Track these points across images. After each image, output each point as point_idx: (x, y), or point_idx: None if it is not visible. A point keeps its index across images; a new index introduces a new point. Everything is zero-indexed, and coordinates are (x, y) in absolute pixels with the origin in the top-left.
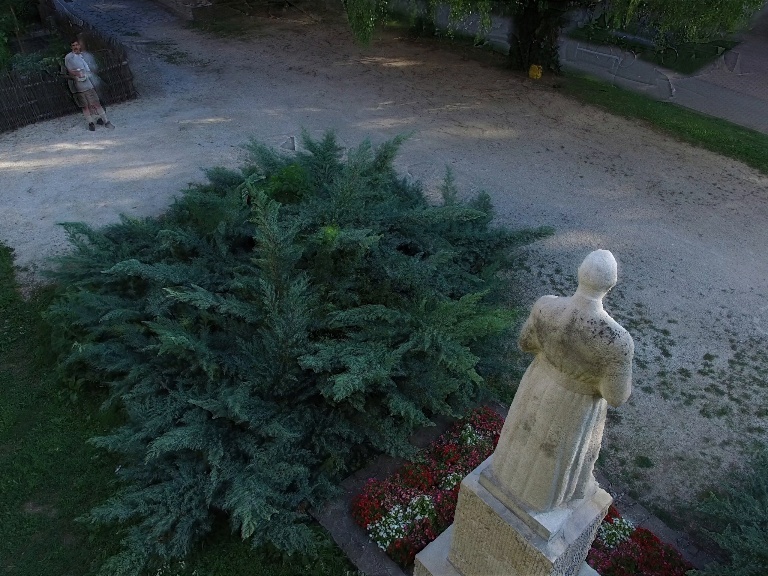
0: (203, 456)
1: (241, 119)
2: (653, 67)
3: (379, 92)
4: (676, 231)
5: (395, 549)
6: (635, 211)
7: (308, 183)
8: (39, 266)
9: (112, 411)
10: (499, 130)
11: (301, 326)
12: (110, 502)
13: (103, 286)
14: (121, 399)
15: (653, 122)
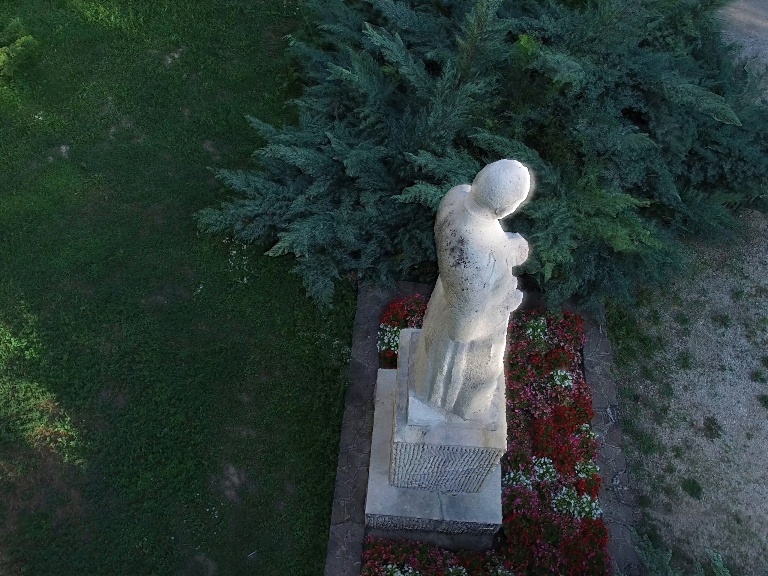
0: None
1: None
2: None
3: None
4: None
5: (385, 356)
6: None
7: None
8: None
9: None
10: None
11: (453, 126)
12: (238, 172)
13: (361, 2)
14: (294, 101)
15: None
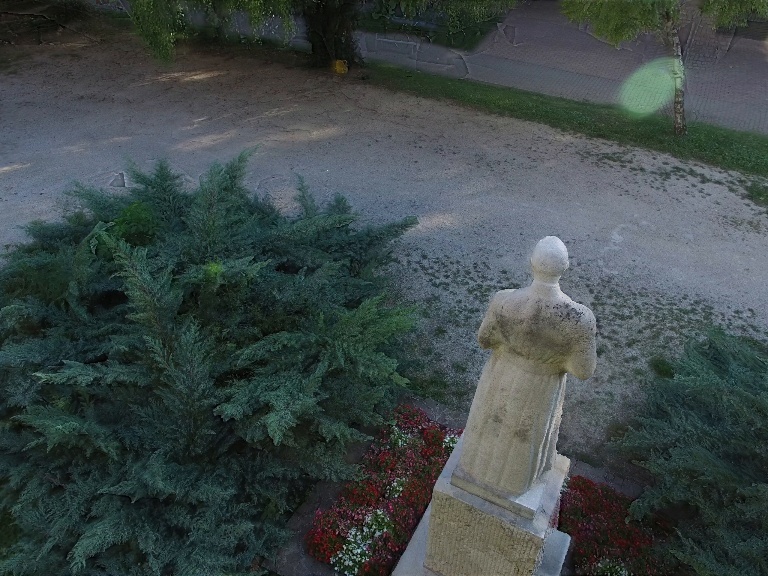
0: (131, 547)
1: (42, 162)
2: (447, 48)
3: (190, 109)
4: (513, 197)
5: (365, 573)
6: (473, 185)
7: (156, 220)
8: None
9: None
10: (325, 129)
11: (204, 375)
12: None
13: None
14: (10, 514)
15: (462, 100)
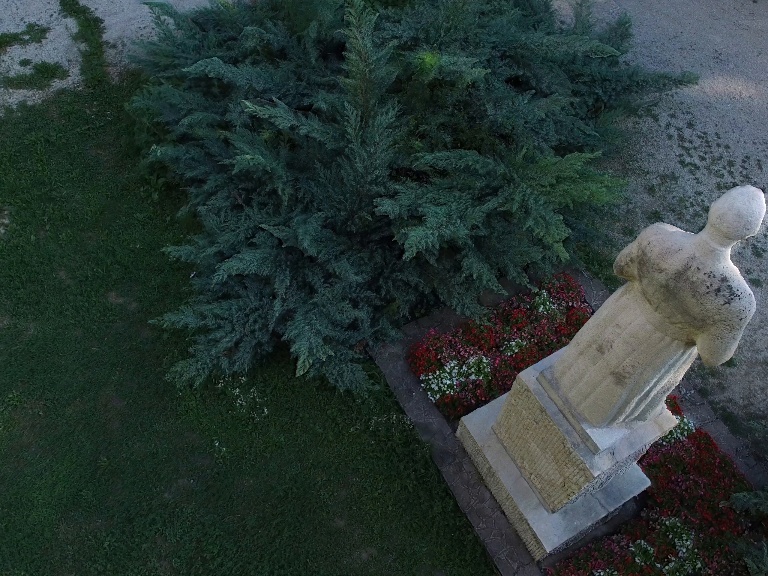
0: (271, 281)
1: None
2: None
3: None
4: None
5: (444, 403)
6: None
7: None
8: (128, 44)
9: (191, 215)
10: None
11: (383, 162)
12: (182, 309)
13: (187, 80)
14: (196, 210)
15: None
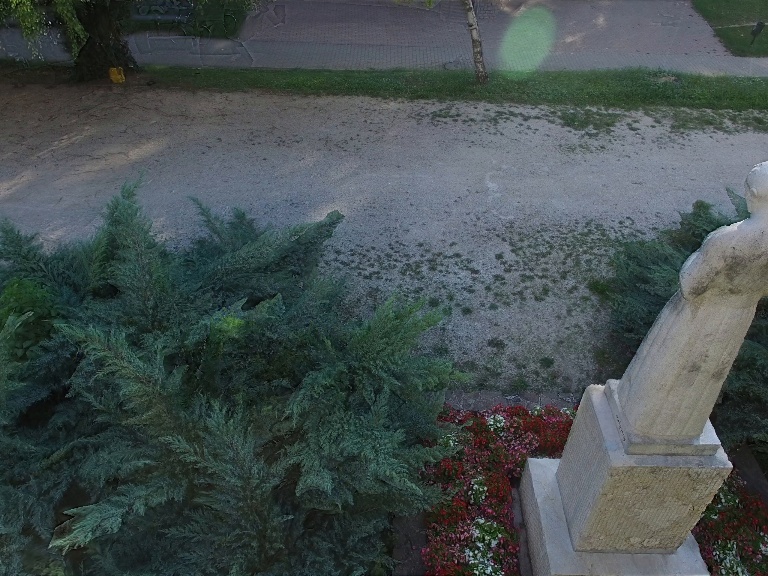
0: None
1: None
2: None
3: None
4: (381, 171)
5: None
6: (337, 169)
7: None
8: None
9: None
10: (141, 147)
11: (251, 456)
12: None
13: None
14: None
15: (269, 87)
